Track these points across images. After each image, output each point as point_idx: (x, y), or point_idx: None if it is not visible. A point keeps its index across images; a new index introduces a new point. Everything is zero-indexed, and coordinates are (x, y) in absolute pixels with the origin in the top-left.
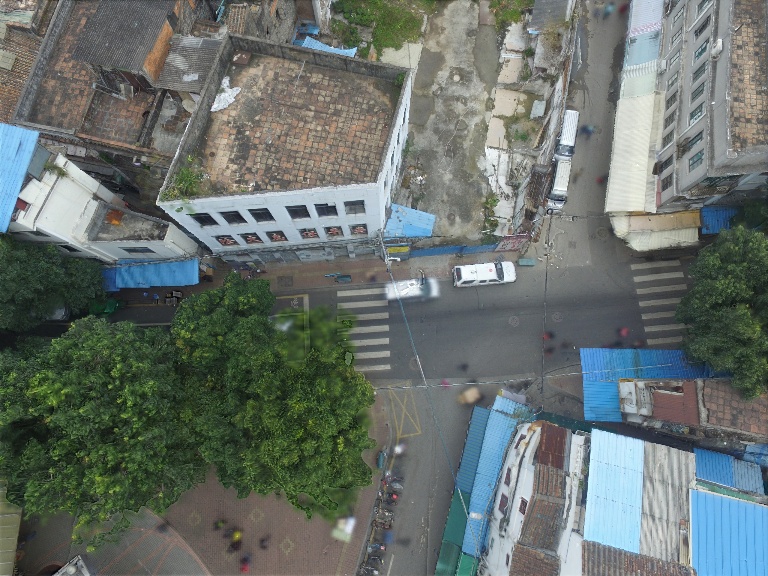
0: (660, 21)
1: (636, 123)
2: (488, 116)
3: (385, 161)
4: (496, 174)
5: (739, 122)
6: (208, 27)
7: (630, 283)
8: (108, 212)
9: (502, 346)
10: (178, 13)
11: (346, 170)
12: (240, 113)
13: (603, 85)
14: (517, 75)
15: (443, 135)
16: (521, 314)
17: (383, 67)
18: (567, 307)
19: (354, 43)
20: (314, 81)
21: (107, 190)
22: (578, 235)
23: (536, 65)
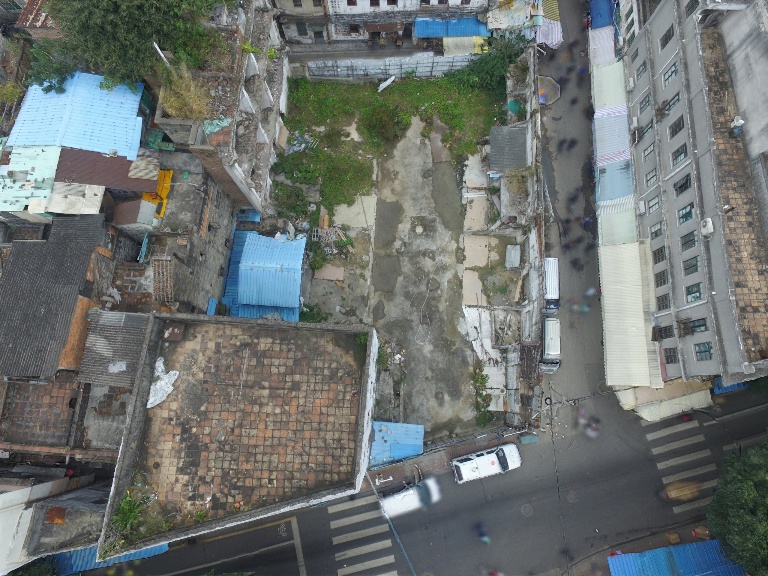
0: (628, 149)
1: (623, 277)
2: (460, 269)
3: (361, 457)
4: (480, 337)
5: (746, 313)
6: (131, 271)
7: (643, 443)
8: (48, 509)
9: (519, 542)
10: (92, 276)
11: (317, 460)
12: (182, 405)
13: (577, 213)
14: (484, 216)
15: (415, 299)
16: (533, 500)
17: (340, 330)
18: (581, 483)
19: (301, 208)
20: (263, 348)
21: (42, 485)
22: (579, 394)
23: (504, 214)
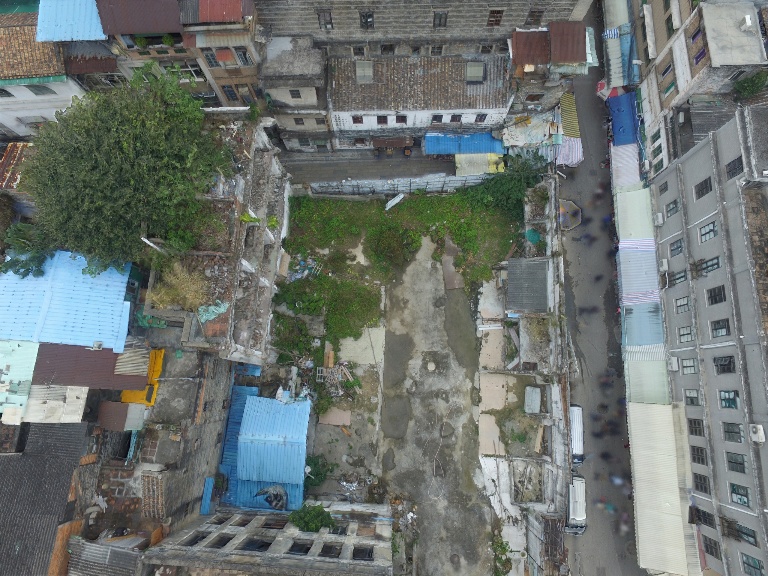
0: (657, 291)
1: (655, 443)
2: (476, 413)
3: None
4: (498, 492)
5: None
6: (119, 471)
7: None
8: None
9: None
10: (74, 495)
11: None
12: None
13: (599, 347)
14: (500, 352)
15: (428, 447)
16: None
17: None
18: None
19: (305, 345)
20: None
21: None
22: (605, 557)
23: (523, 361)
